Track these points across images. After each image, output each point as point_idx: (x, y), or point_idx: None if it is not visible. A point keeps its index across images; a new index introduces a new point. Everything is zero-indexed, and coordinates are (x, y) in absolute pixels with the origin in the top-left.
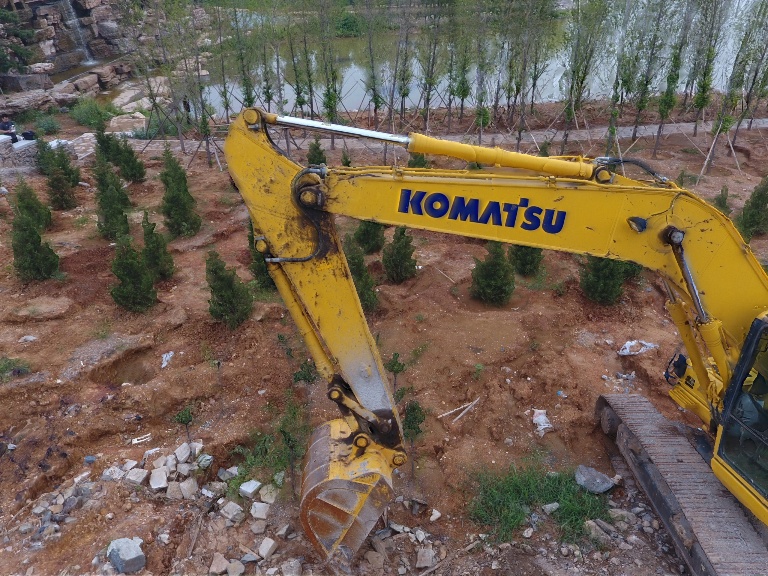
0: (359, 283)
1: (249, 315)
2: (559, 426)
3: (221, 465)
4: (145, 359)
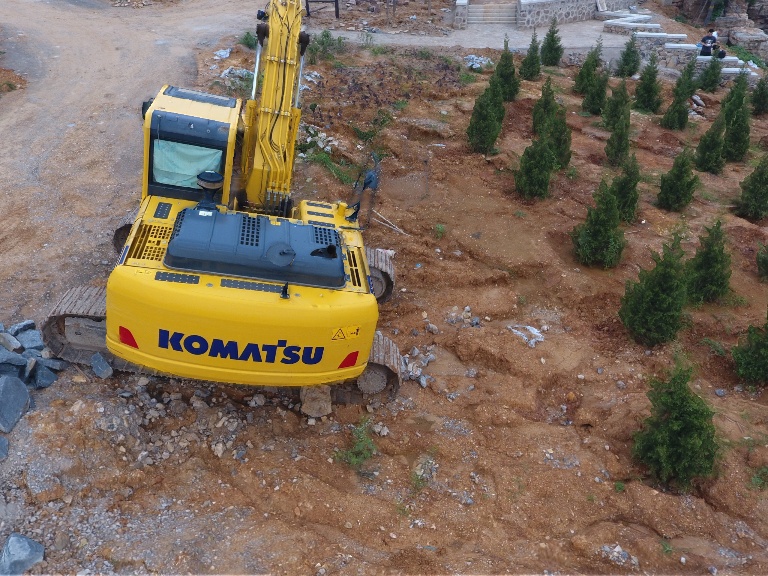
0: (522, 164)
1: (489, 154)
2: None
3: (335, 161)
4: (436, 141)
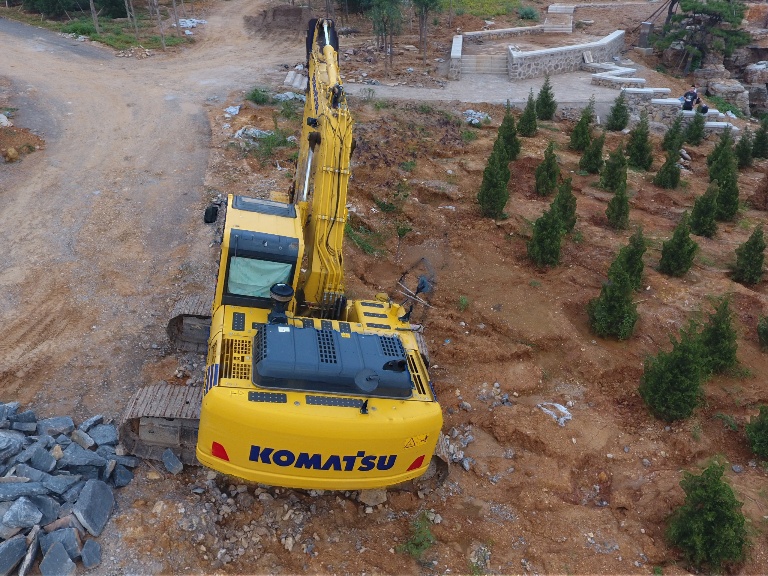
0: (534, 234)
1: (498, 219)
2: None
3: (354, 227)
4: (446, 203)
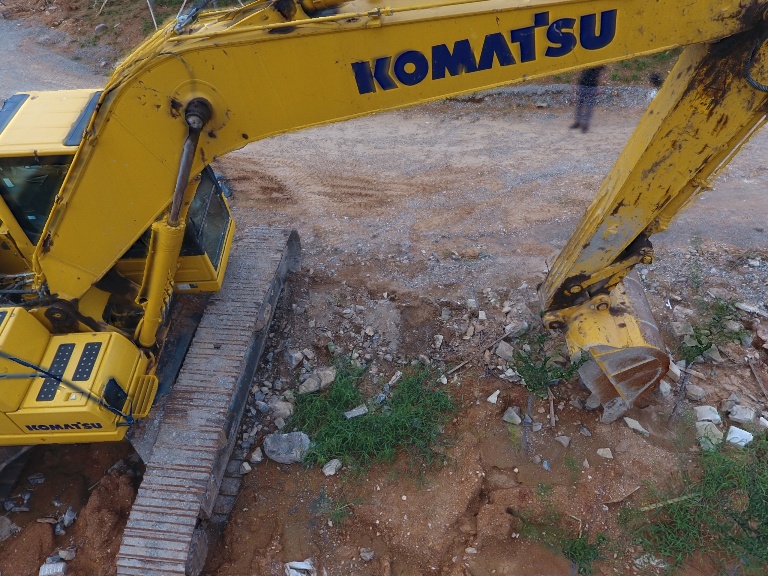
0: None
1: None
2: (275, 568)
3: None
4: None
